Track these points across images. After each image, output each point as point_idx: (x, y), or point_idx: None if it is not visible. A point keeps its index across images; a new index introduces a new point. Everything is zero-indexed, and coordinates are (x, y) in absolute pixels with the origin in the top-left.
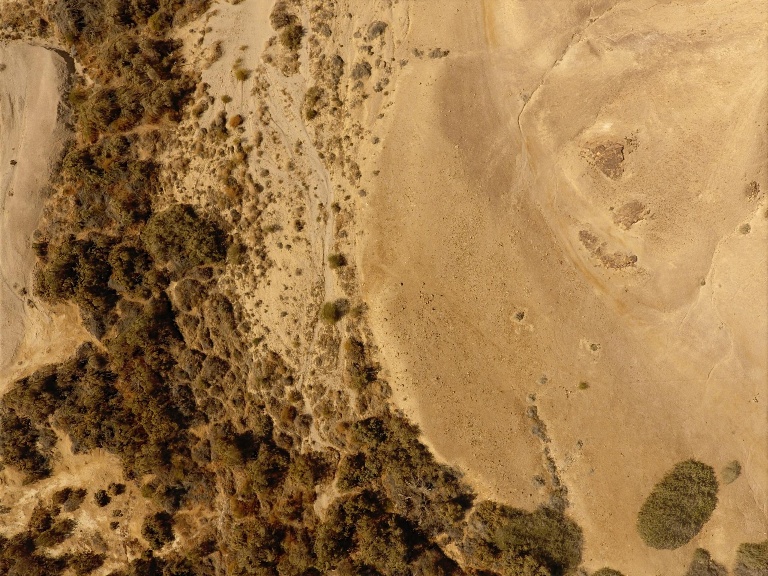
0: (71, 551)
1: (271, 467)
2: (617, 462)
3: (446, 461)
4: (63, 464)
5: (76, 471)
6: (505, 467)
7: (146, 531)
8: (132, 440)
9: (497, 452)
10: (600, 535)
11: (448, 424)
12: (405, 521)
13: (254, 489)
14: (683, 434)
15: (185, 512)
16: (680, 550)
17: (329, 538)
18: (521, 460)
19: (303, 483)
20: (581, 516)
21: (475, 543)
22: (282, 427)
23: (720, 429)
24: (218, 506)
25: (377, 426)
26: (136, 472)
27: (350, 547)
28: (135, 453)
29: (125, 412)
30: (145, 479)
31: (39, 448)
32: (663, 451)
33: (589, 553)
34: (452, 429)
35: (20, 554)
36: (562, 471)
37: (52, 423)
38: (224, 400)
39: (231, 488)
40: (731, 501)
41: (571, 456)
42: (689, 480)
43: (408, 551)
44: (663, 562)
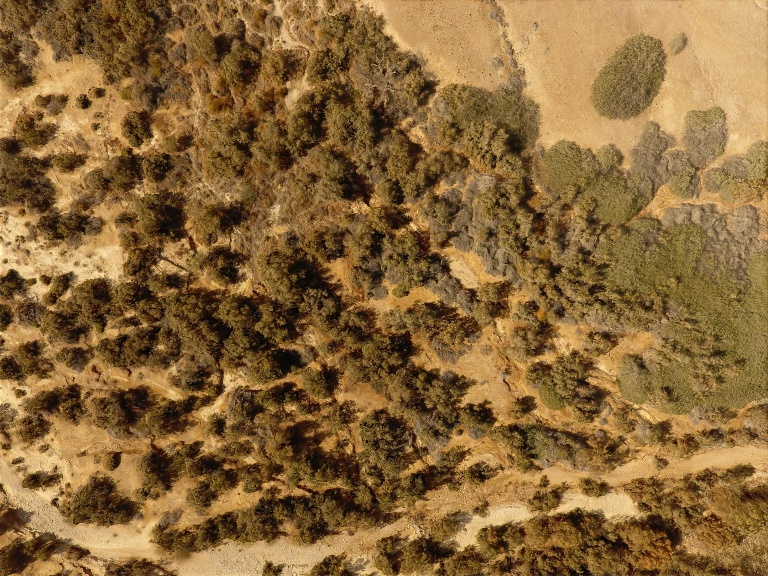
0: (54, 152)
1: (243, 58)
2: (571, 39)
3: (409, 47)
4: (45, 72)
5: (58, 79)
6: (465, 49)
7: (125, 123)
8: (111, 44)
9: (458, 36)
10: (556, 108)
11: (411, 12)
12: (372, 108)
13: (227, 77)
14: (633, 11)
15: (163, 111)
16: (631, 121)
17: (299, 115)
18: (480, 43)
19: (274, 68)
20: (538, 92)
21: (438, 123)
22: (254, 28)
23: (667, 4)
24: (194, 105)
25: (344, 17)
26: (115, 75)
27: (320, 137)
28: (114, 53)
29: (103, 16)
30: (124, 83)
31: (22, 58)
32: (614, 28)
33: (546, 127)
34: (415, 17)
35: (5, 147)
36: (519, 53)
37: (34, 34)
38: (198, 6)
39: (206, 87)
40: (678, 71)
41: (528, 37)
42: (638, 49)
43: (374, 129)
44: (615, 131)
